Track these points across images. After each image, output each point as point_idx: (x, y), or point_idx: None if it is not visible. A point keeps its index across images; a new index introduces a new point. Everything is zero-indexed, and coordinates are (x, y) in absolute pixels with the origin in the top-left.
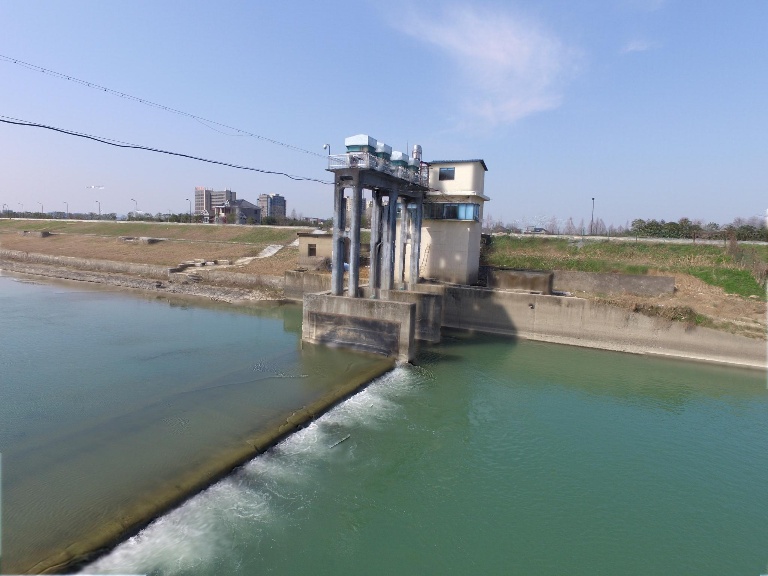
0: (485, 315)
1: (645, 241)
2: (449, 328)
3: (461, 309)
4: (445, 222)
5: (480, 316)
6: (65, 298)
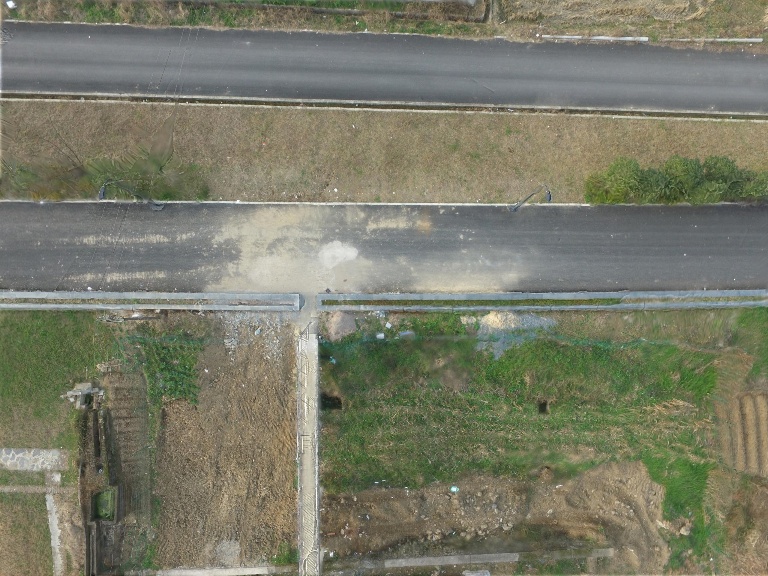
0: None
1: (612, 322)
2: None
3: None
4: None
5: None
6: None
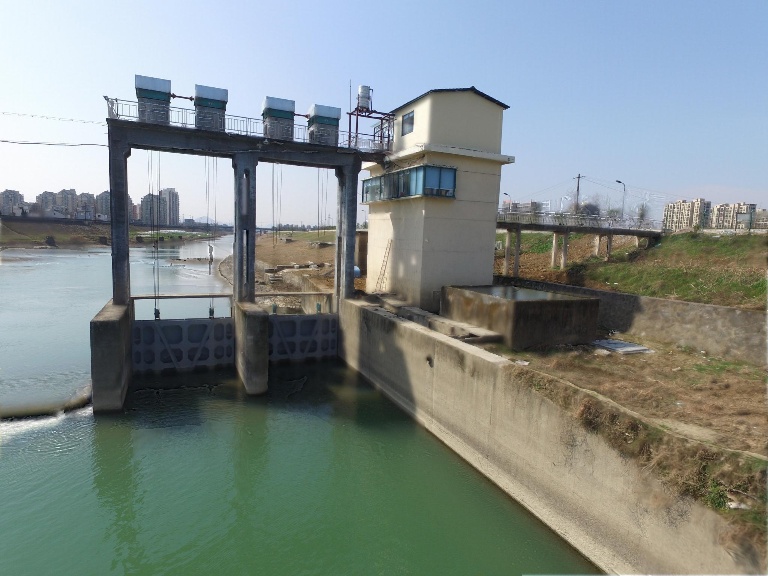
0: (388, 364)
1: None
2: (362, 376)
3: (371, 347)
4: (401, 202)
5: (384, 364)
6: (160, 289)
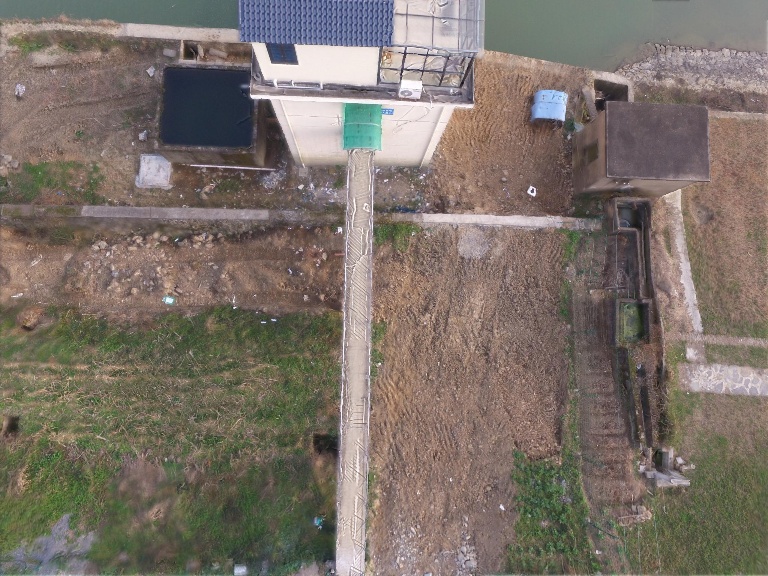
0: None
1: None
2: None
3: None
4: None
5: None
6: None
